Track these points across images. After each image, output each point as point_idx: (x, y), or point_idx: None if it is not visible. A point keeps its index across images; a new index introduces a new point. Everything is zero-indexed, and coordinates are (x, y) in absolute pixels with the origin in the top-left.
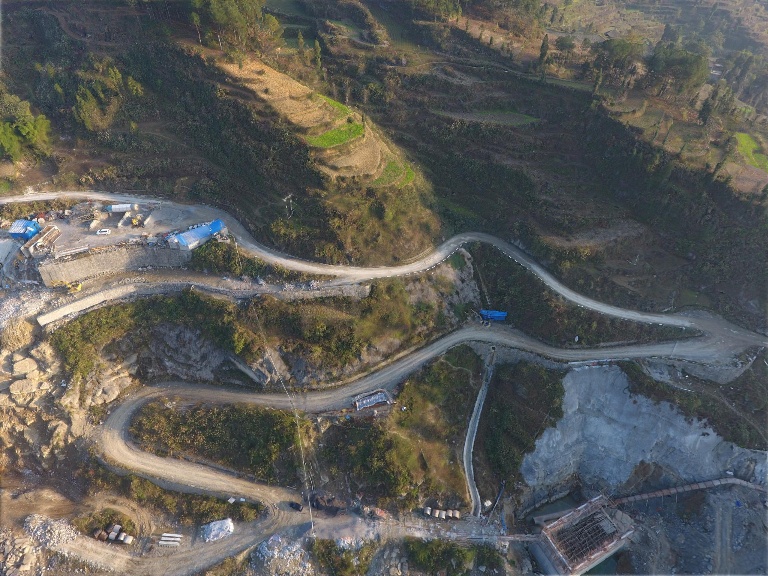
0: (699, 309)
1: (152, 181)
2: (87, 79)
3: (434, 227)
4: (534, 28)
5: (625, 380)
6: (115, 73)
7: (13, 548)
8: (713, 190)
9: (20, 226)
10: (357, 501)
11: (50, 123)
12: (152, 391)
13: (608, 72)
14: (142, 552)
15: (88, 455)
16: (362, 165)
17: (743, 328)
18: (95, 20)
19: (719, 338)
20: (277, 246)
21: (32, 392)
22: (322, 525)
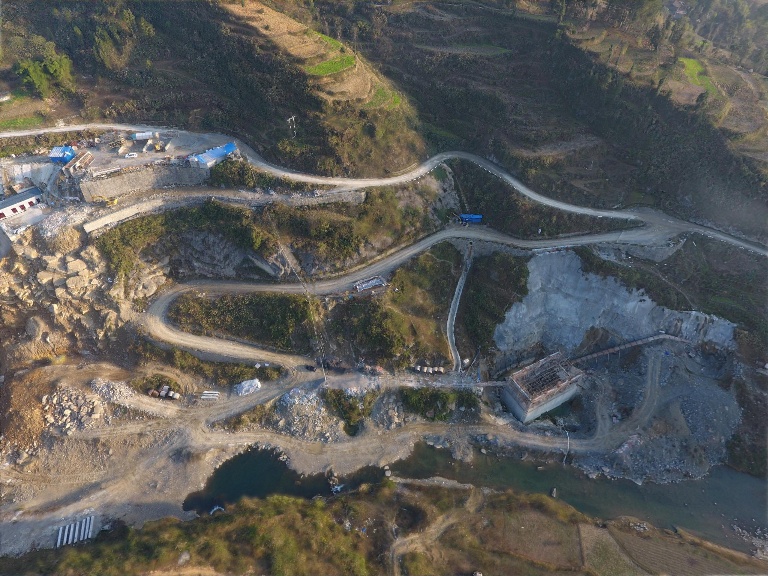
0: (644, 206)
1: (169, 113)
2: (103, 22)
3: (419, 146)
4: None
5: (579, 262)
6: (129, 15)
7: (85, 402)
8: (657, 104)
9: (59, 151)
10: (360, 363)
11: None
12: (184, 287)
13: (573, 5)
14: (188, 405)
15: (136, 335)
16: (355, 91)
17: (679, 219)
18: None
19: (658, 227)
20: (284, 163)
21: (85, 286)
22: (333, 380)
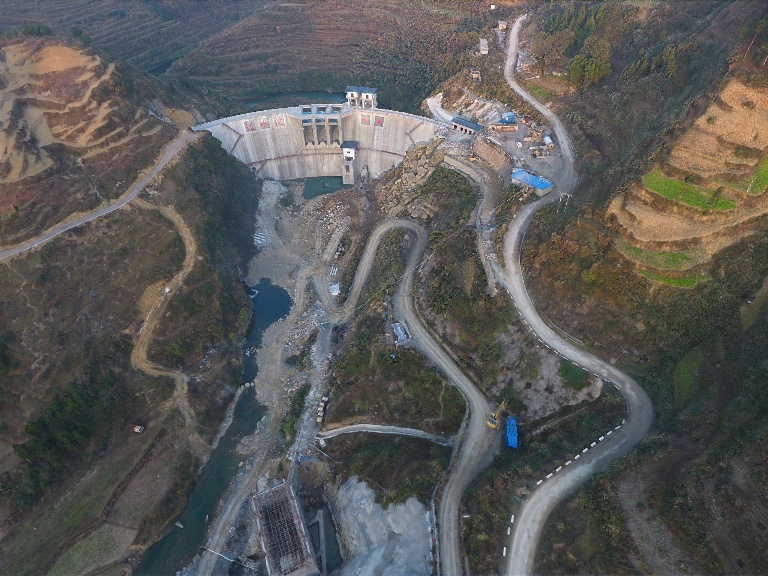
0: None
1: None
2: None
3: (618, 340)
4: None
5: None
6: (670, 53)
7: None
8: None
9: (508, 115)
10: None
11: None
12: (421, 230)
13: None
14: (330, 263)
15: None
16: (648, 227)
17: None
18: None
19: None
20: None
21: None
22: (326, 334)
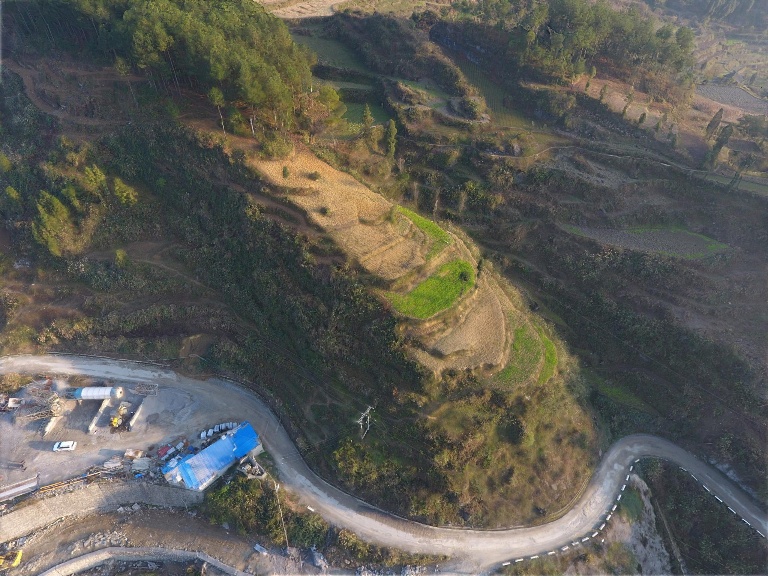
0: None
1: (146, 342)
2: (56, 177)
3: (588, 438)
4: (690, 94)
5: None
6: (95, 174)
7: None
8: None
9: None
10: None
11: (2, 238)
12: None
13: None
14: None
15: None
16: (480, 344)
17: None
18: (72, 85)
19: None
20: (343, 482)
21: None
22: None
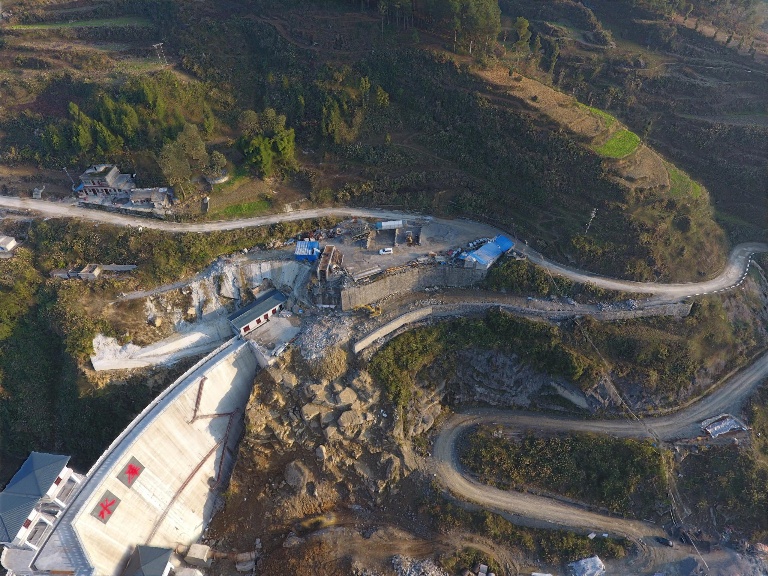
0: None
1: (411, 196)
2: (327, 90)
3: None
4: None
5: None
6: (366, 83)
7: None
8: None
9: (305, 247)
10: (725, 534)
11: None
12: (464, 419)
13: None
14: None
15: (431, 490)
16: (653, 175)
17: None
18: (322, 27)
19: None
20: (573, 263)
21: (359, 424)
22: None
